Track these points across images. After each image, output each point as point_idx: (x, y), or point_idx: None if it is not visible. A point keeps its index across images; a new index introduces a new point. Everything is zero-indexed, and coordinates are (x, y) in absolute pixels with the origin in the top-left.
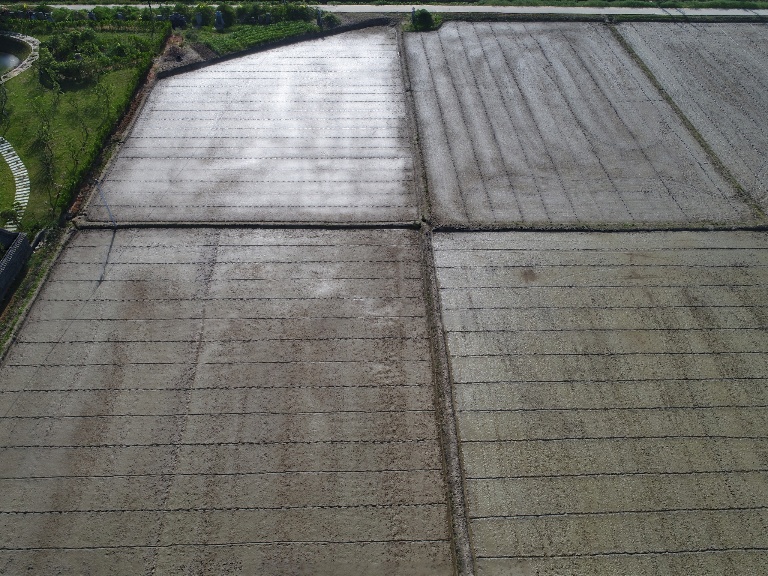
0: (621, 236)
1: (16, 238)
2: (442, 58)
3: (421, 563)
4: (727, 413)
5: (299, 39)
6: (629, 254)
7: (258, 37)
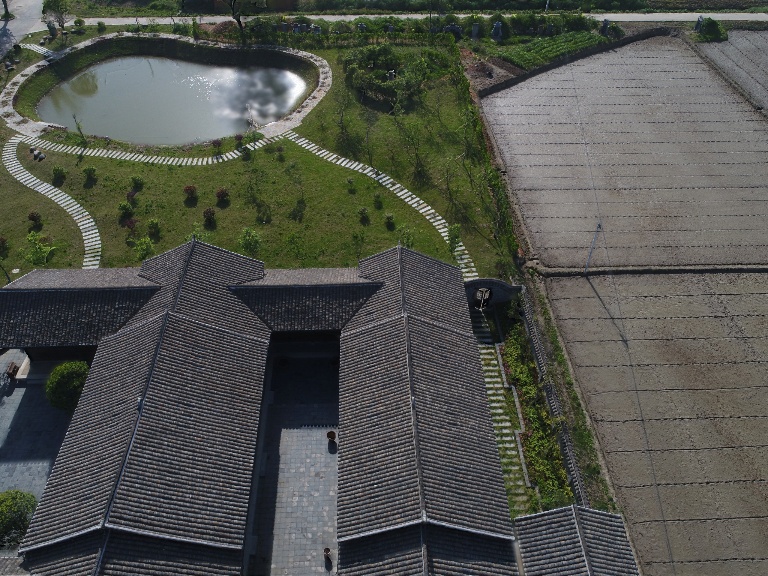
0: None
1: (525, 293)
2: (761, 71)
3: None
4: None
5: (592, 51)
6: None
7: (555, 50)
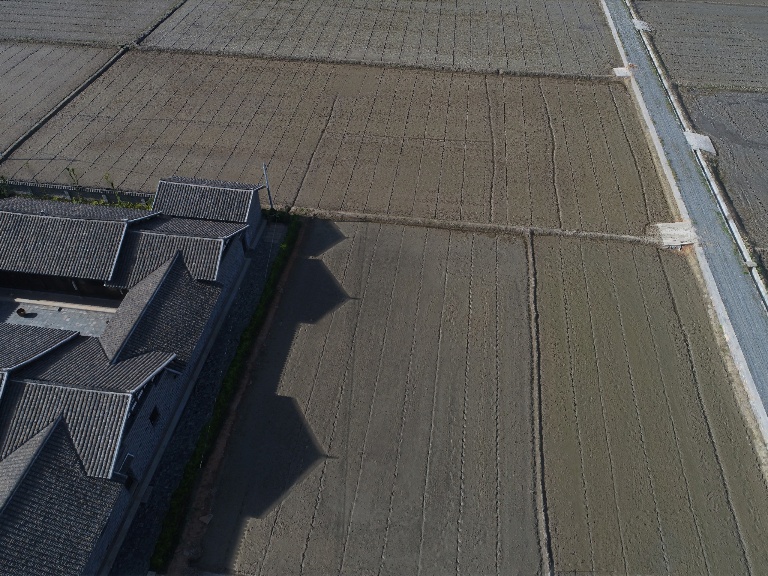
0: (189, 2)
1: None
2: None
3: None
4: (308, 6)
5: None
6: (204, 3)
7: None
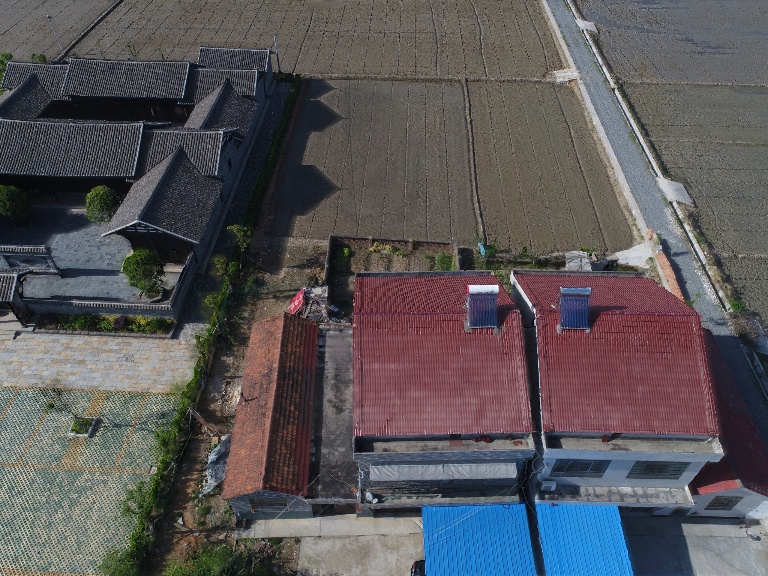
0: None
1: None
2: None
3: None
4: None
5: None
6: None
7: None
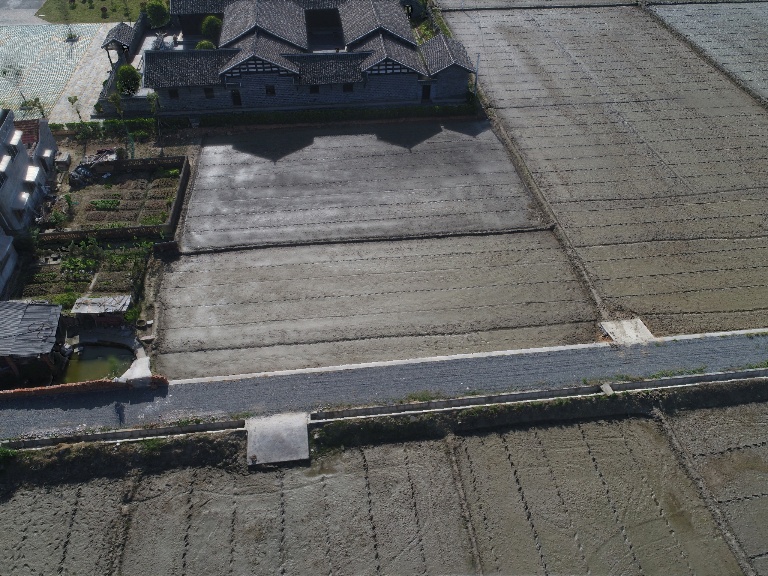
0: (751, 4)
1: (428, 5)
2: None
3: (730, 93)
4: None
5: None
6: (760, 9)
7: None
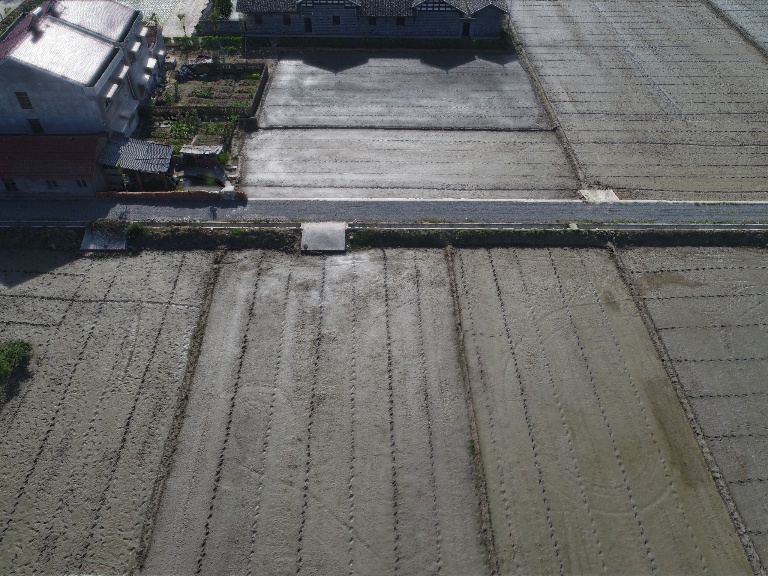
0: None
1: None
2: None
3: None
4: None
5: None
6: None
7: None
